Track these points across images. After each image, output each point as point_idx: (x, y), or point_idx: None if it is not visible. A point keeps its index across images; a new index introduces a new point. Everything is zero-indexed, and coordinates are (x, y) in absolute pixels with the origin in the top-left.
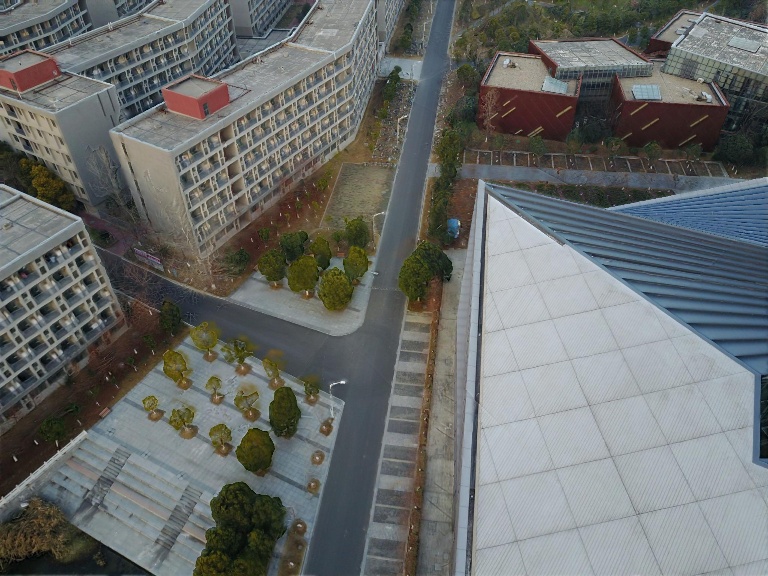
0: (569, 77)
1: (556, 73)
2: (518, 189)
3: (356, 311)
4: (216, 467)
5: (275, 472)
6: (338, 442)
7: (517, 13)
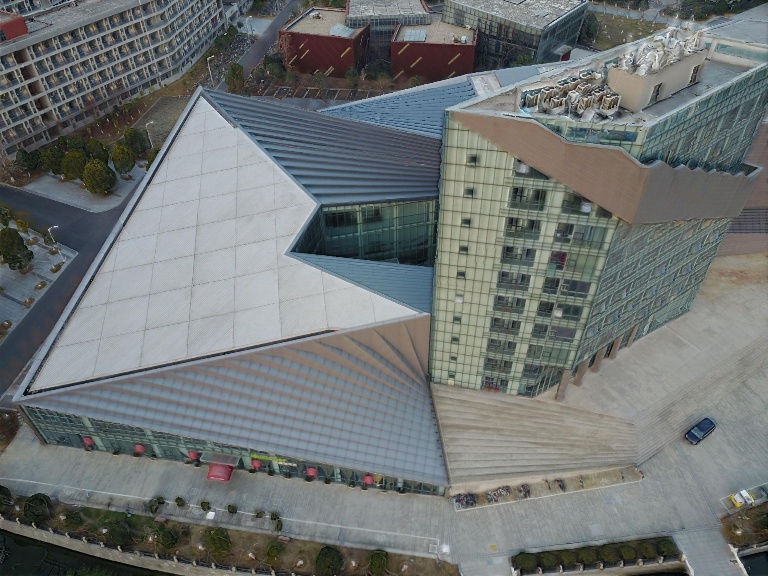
0: (358, 25)
1: (346, 21)
2: None
3: (119, 196)
4: None
5: (4, 293)
6: (61, 276)
7: None
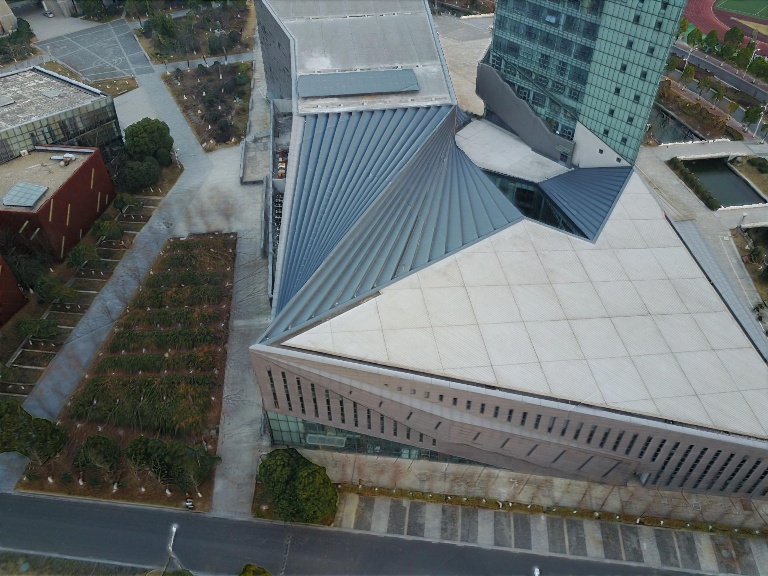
0: None
1: None
2: (111, 370)
3: None
4: None
5: None
6: None
7: None
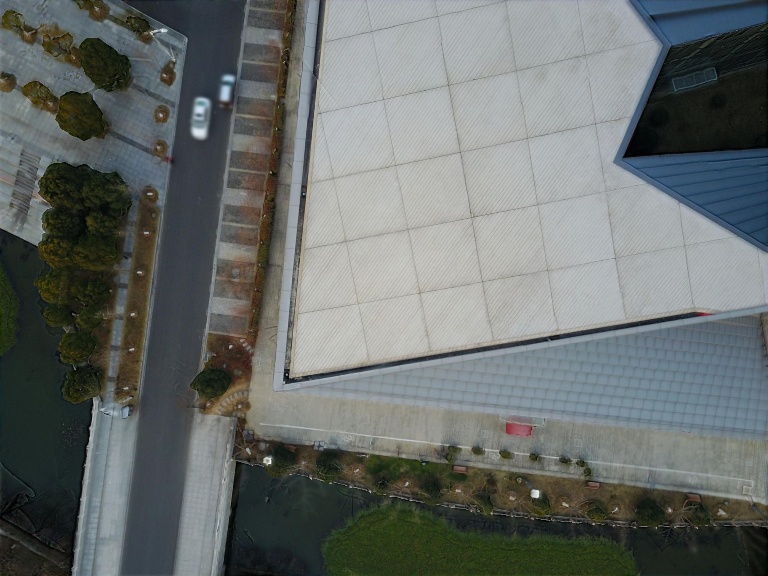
0: None
1: None
2: None
3: None
4: (48, 127)
5: (116, 133)
6: (183, 94)
7: None
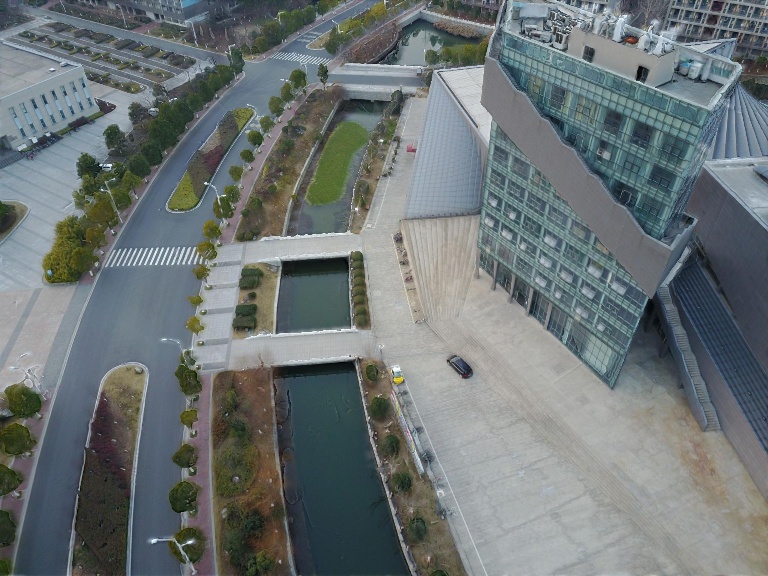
0: None
1: None
2: None
3: None
4: None
5: None
6: None
7: None
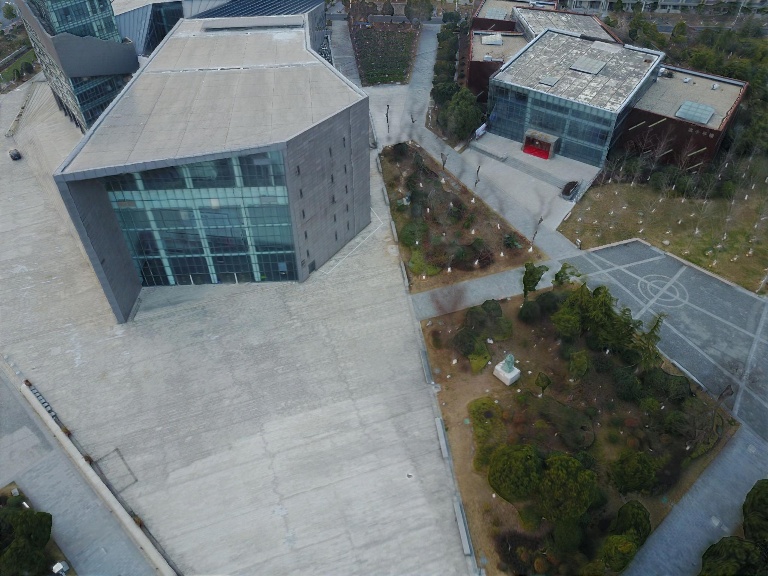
0: None
1: None
2: None
3: None
4: None
5: None
6: None
7: (707, 31)
